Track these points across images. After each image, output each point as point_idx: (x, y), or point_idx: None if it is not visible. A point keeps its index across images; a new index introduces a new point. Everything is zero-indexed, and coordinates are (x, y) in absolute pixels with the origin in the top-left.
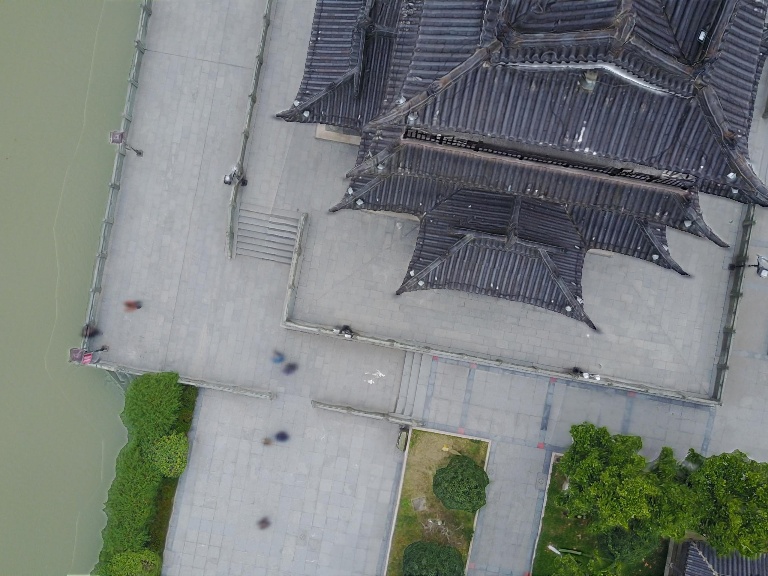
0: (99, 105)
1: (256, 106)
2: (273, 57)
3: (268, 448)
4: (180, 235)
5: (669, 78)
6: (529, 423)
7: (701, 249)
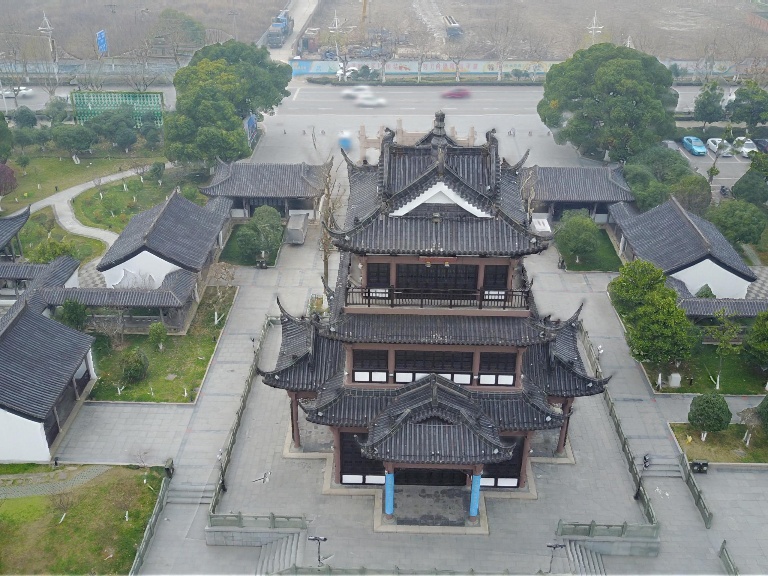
0: None
1: None
2: None
3: (767, 554)
4: None
5: None
6: (643, 407)
7: None
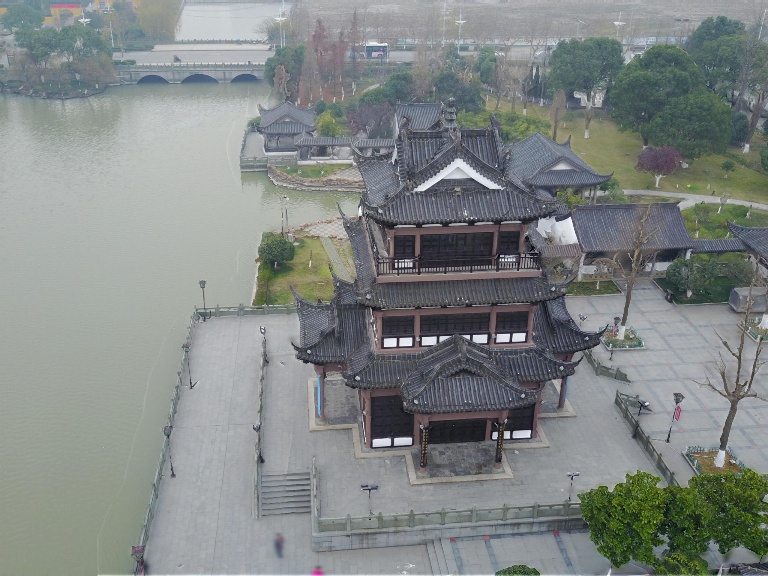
0: (134, 473)
1: (262, 426)
2: (269, 404)
3: None
4: (212, 514)
5: (491, 176)
6: (555, 564)
7: (607, 434)
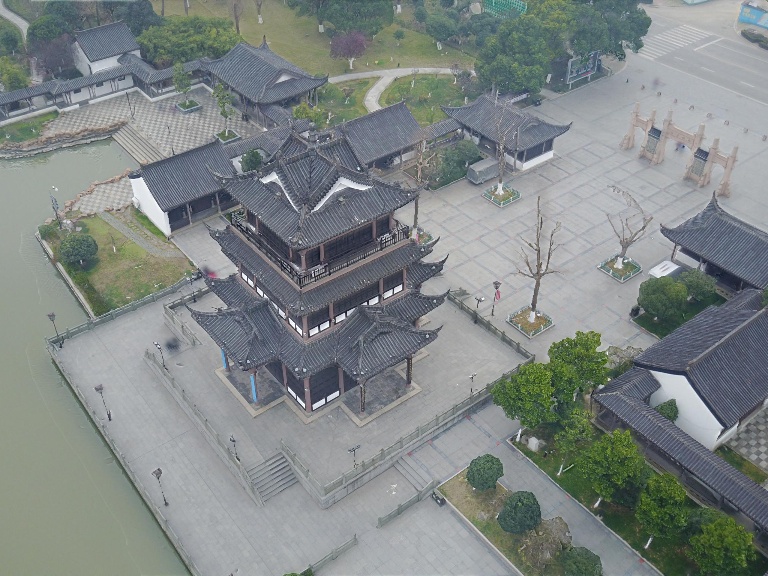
0: (119, 516)
1: None
2: (201, 408)
3: (381, 569)
4: (225, 520)
5: (362, 180)
6: (482, 440)
7: (458, 327)
